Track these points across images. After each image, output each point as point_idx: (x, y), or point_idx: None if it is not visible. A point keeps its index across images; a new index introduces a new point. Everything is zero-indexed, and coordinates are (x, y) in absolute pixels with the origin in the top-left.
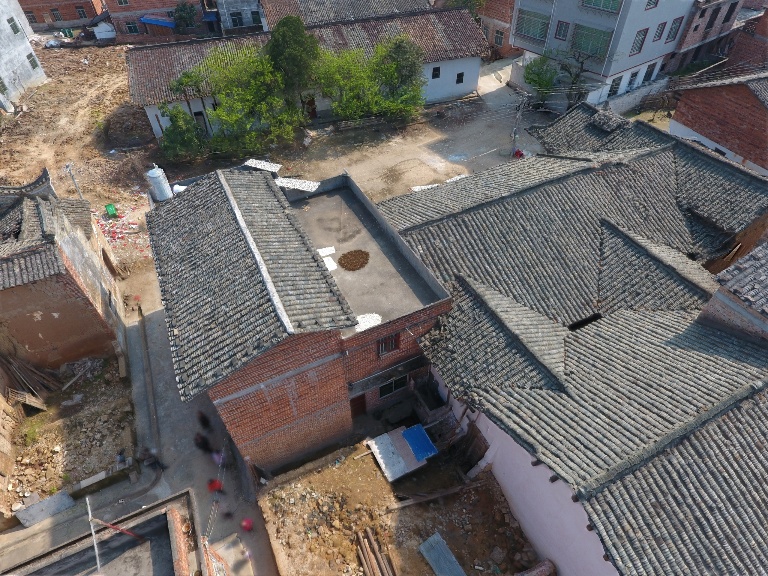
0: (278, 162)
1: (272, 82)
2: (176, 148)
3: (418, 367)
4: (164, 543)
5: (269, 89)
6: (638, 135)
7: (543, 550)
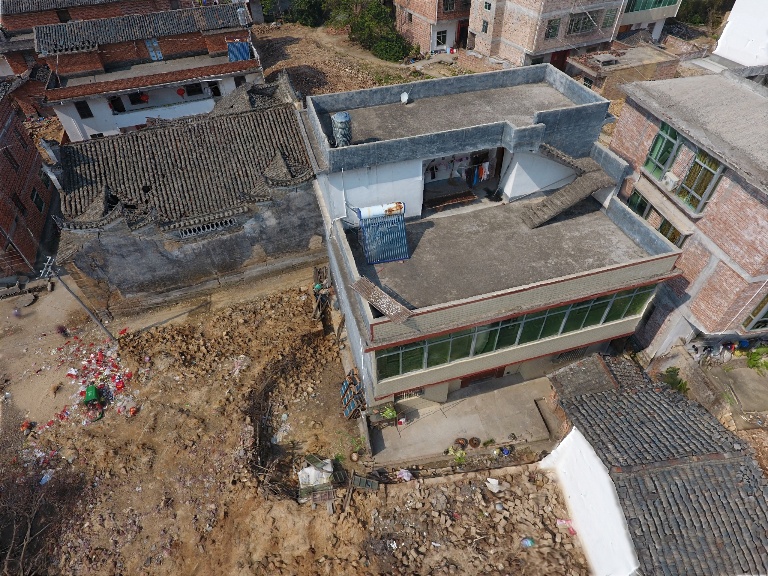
0: None
1: None
2: None
3: None
4: None
5: None
6: None
7: None
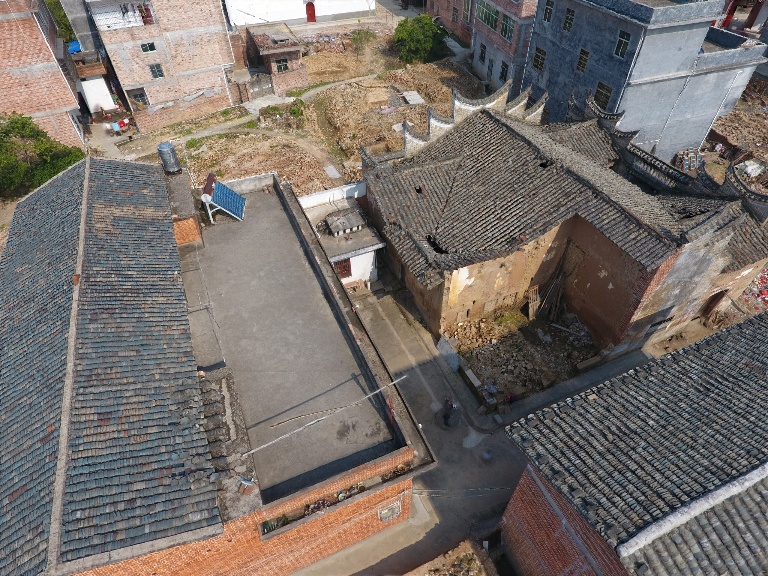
0: None
1: None
2: None
3: None
4: (390, 451)
5: None
6: None
7: None
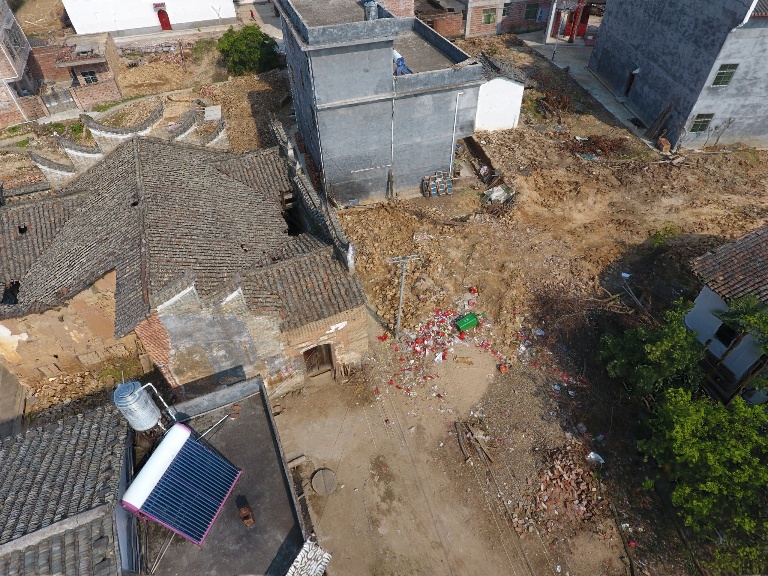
0: (704, 574)
1: None
2: (614, 359)
3: None
4: None
5: None
6: None
7: None
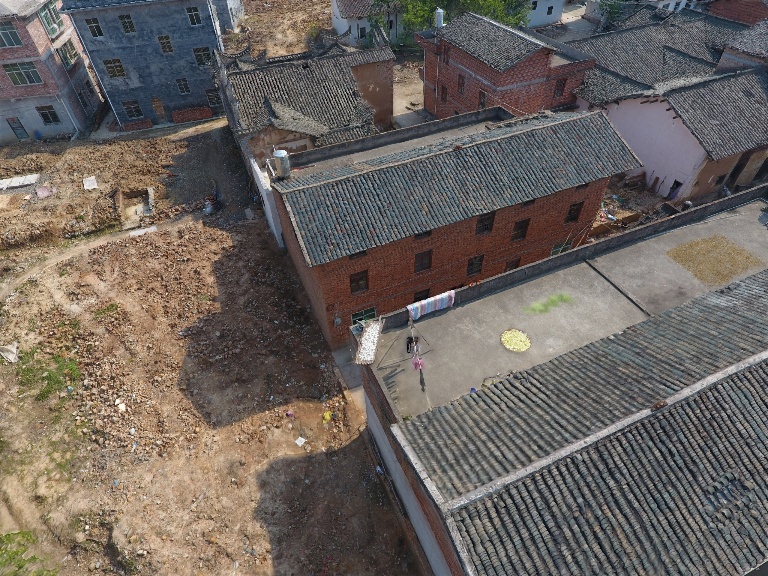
0: None
1: (439, 0)
2: None
3: (570, 109)
4: None
5: (435, 6)
6: (683, 16)
7: (638, 171)
